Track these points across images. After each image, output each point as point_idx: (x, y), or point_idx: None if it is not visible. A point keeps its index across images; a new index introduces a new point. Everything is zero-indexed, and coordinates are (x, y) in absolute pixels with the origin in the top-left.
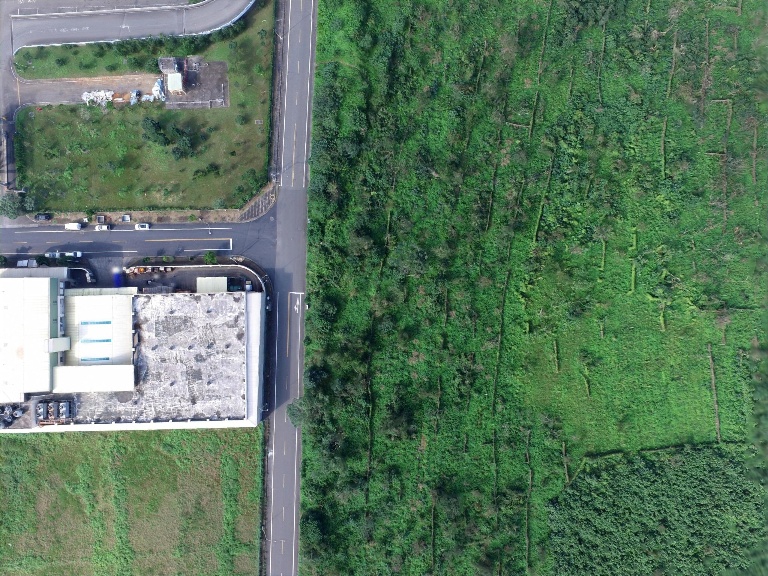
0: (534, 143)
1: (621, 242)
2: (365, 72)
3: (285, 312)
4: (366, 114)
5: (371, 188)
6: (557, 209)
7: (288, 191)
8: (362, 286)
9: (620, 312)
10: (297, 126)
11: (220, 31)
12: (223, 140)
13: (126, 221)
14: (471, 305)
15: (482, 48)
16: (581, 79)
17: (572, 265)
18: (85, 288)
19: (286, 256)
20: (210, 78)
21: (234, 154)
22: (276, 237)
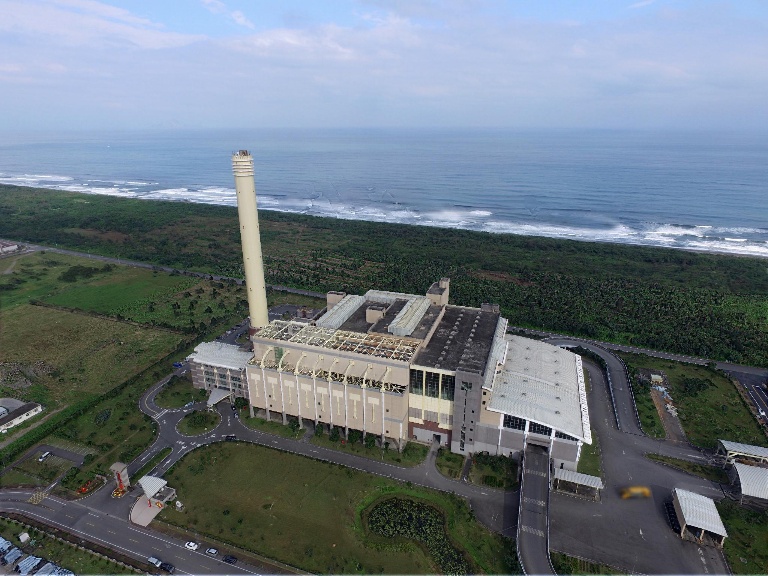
0: None
1: None
2: None
3: None
4: None
5: None
6: None
7: None
8: None
9: None
10: None
11: None
12: None
13: (761, 417)
14: None
15: None
16: None
17: None
18: None
19: None
20: None
21: (697, 370)
22: None
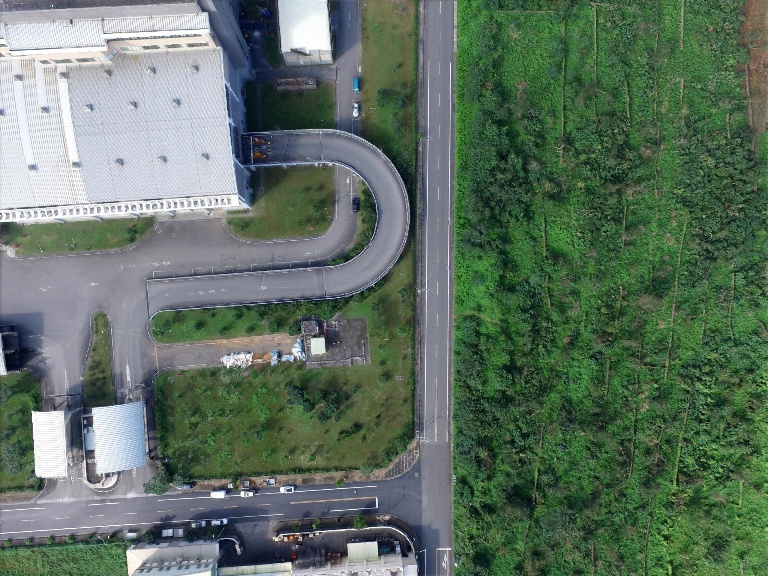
0: (670, 384)
1: (756, 477)
2: (505, 325)
3: (433, 569)
4: (511, 373)
5: (519, 448)
6: (694, 449)
7: (432, 446)
8: (509, 540)
9: (758, 548)
10: (438, 380)
11: (362, 293)
12: (365, 398)
13: (271, 485)
14: (616, 552)
15: (618, 294)
16: (713, 317)
17: (710, 503)
18: (239, 566)
19: (432, 512)
20: (350, 335)
21: (380, 416)
22: (421, 493)
